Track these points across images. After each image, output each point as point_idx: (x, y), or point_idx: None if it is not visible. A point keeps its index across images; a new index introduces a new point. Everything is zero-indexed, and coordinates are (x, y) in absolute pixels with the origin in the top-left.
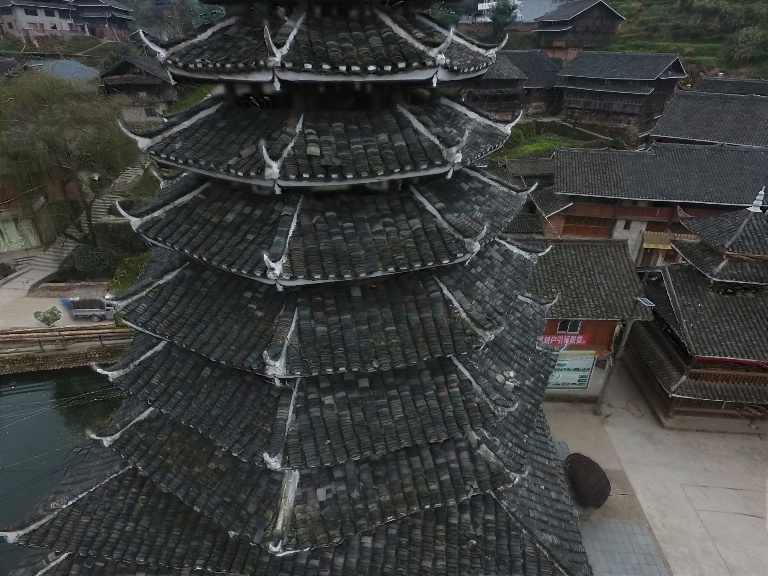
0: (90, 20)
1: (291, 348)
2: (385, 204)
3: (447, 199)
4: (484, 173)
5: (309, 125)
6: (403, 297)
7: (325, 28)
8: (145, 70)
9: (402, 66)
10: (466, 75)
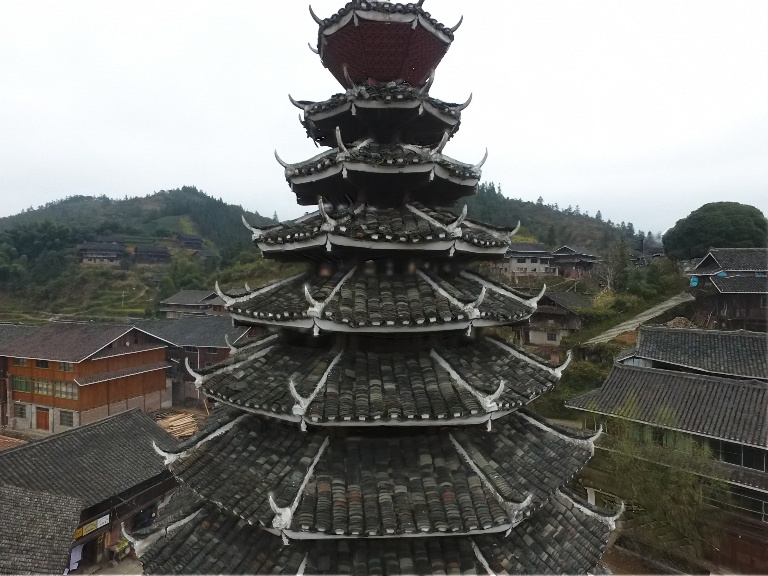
0: (562, 264)
1: (162, 539)
2: (290, 441)
3: (362, 462)
4: (471, 454)
5: (266, 354)
6: (261, 552)
7: (304, 283)
8: (557, 303)
9: (287, 315)
10: (394, 328)
